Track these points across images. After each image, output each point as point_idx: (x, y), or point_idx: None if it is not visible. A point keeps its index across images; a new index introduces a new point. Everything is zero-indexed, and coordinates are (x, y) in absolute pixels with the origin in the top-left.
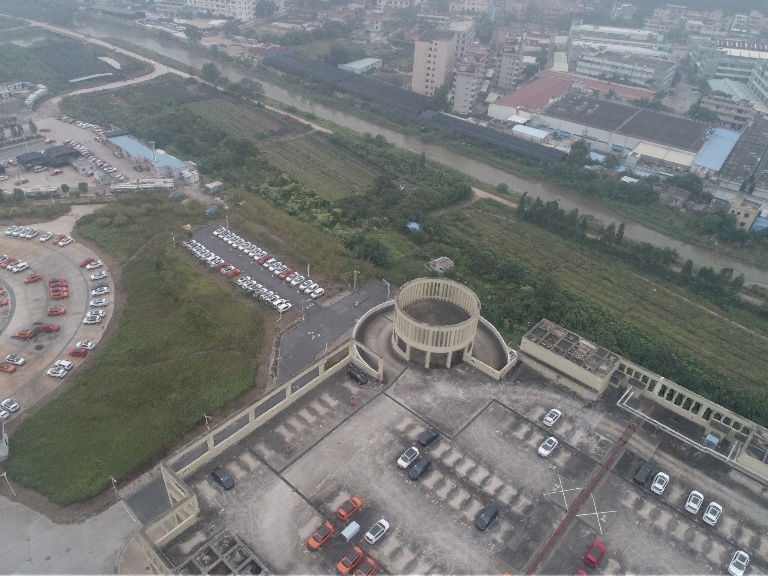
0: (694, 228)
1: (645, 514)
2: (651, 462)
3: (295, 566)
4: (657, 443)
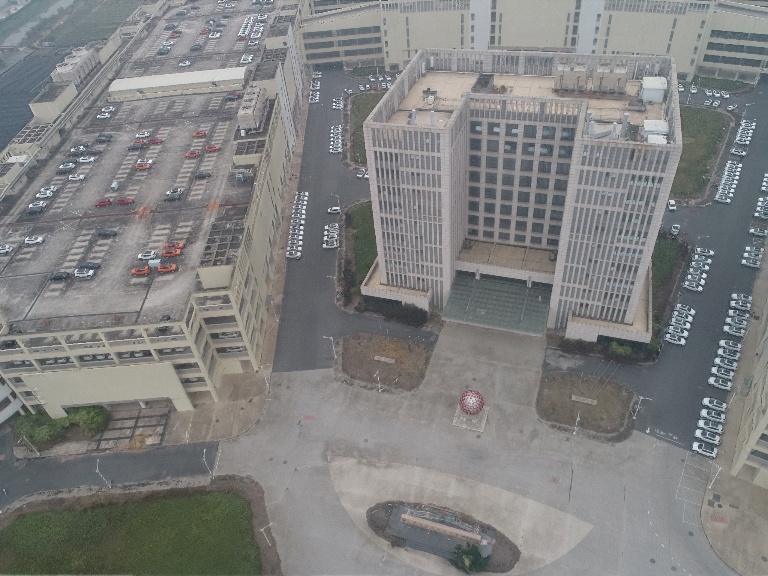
0: None
1: (63, 204)
2: (21, 214)
3: (191, 267)
4: (2, 217)
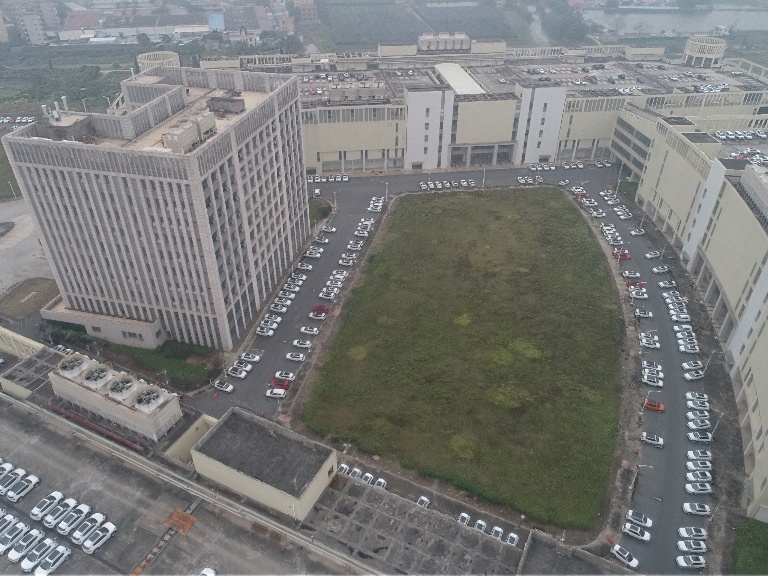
0: (231, 54)
1: None
2: None
3: None
4: None
